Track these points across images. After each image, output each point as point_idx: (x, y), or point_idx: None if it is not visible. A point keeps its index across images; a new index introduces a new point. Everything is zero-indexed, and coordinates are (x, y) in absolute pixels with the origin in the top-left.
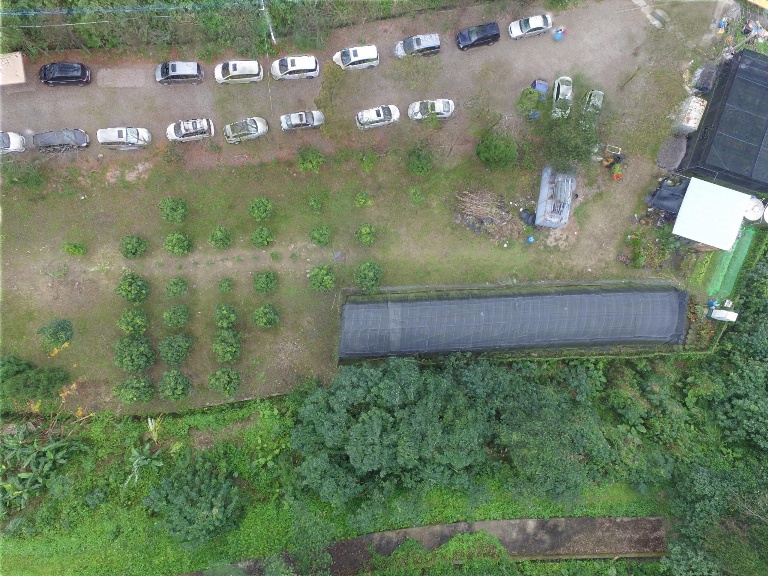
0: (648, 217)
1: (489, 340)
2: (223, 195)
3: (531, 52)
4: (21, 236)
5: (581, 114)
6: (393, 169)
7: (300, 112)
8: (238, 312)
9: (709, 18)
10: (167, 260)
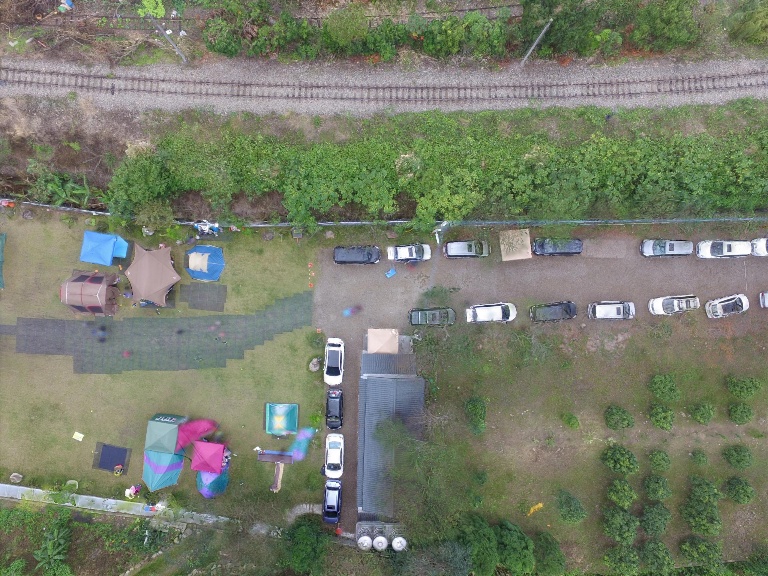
0: None
1: None
2: (695, 366)
3: None
4: (505, 400)
5: None
6: None
7: None
8: None
9: None
10: (644, 430)
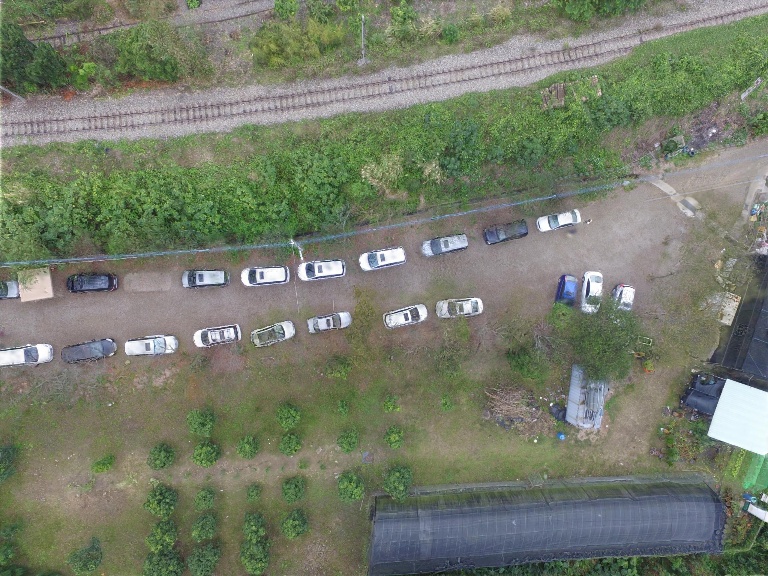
0: (681, 409)
1: (521, 548)
2: (250, 397)
3: (559, 244)
4: (49, 445)
5: (612, 309)
6: (421, 366)
7: (327, 317)
8: (266, 516)
9: (740, 204)
10: (195, 467)
